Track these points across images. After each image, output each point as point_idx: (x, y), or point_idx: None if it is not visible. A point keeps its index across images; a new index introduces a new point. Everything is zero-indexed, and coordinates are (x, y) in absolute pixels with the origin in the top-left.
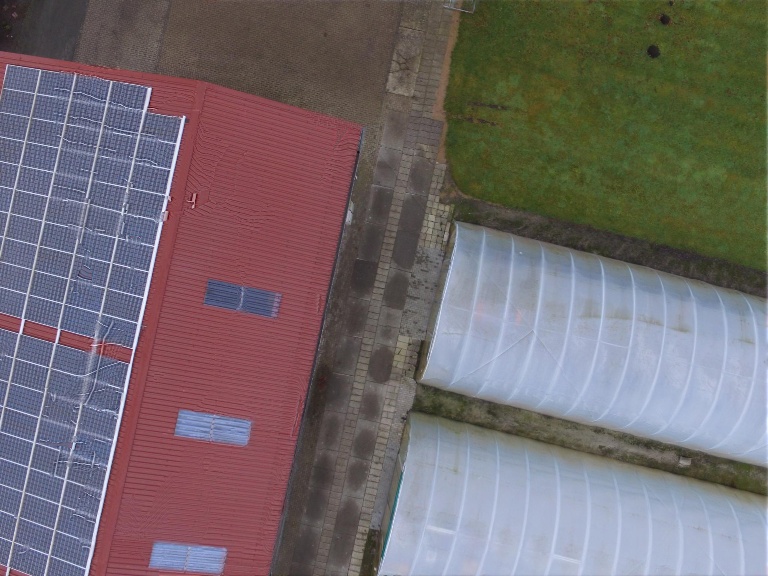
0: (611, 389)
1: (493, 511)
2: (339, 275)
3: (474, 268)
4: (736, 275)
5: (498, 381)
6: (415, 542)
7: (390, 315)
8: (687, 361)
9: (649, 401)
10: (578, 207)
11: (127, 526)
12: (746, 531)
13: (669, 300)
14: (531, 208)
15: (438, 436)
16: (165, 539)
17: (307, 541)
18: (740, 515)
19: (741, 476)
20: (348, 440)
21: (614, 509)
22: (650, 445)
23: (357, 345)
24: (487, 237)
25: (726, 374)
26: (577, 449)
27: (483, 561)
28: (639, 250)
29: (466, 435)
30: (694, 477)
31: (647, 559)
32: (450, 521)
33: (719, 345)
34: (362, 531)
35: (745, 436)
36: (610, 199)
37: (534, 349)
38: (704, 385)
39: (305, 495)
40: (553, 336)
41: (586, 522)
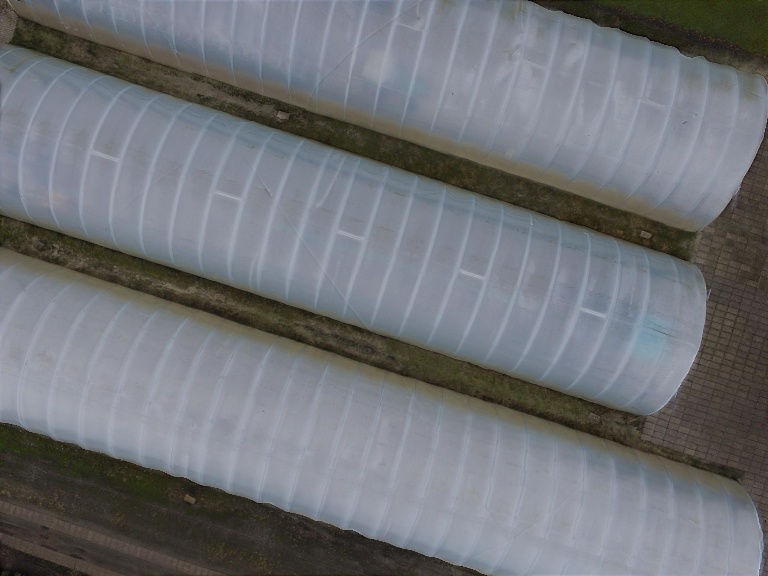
0: None
1: (37, 105)
2: None
3: None
4: None
5: None
6: None
7: None
8: None
9: (205, 11)
10: None
11: None
12: None
13: None
14: None
15: (12, 49)
16: None
17: None
18: (313, 153)
19: (338, 134)
20: None
21: (168, 120)
22: (249, 97)
23: None
24: None
25: None
26: (175, 95)
27: (22, 152)
28: None
29: (48, 57)
30: (291, 132)
31: (187, 163)
32: None
33: None
34: None
35: (308, 61)
36: None
37: None
38: None
39: None
40: None
41: (132, 125)
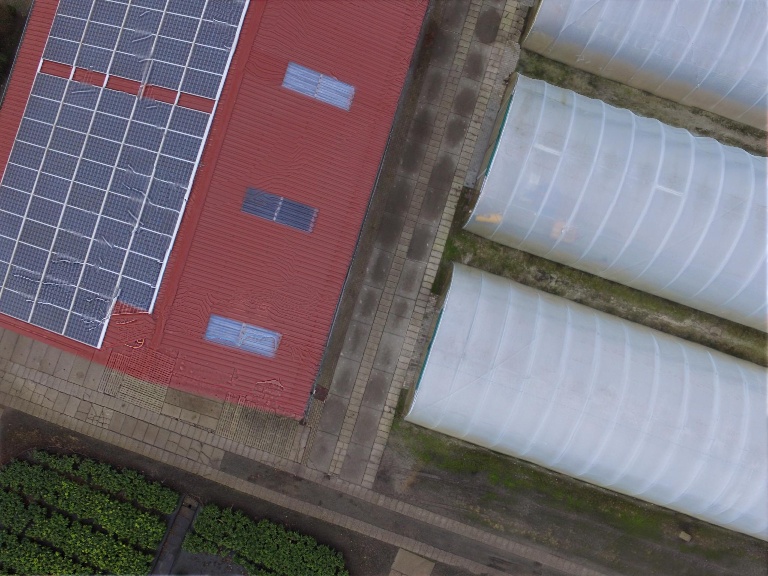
0: (724, 32)
1: (600, 138)
2: None
3: None
4: None
5: (610, 26)
6: (521, 158)
7: None
8: None
9: (761, 48)
10: None
11: (277, 6)
12: None
13: None
14: None
15: (544, 81)
16: (300, 59)
17: (401, 192)
18: None
19: None
20: (450, 96)
21: (717, 155)
22: (747, 131)
23: (466, 5)
24: None
25: None
26: None
27: (587, 184)
28: None
29: None
30: None
31: (749, 198)
32: (557, 141)
33: None
34: (456, 187)
35: None
36: None
37: None
38: None
39: (403, 147)
40: None
41: (690, 159)
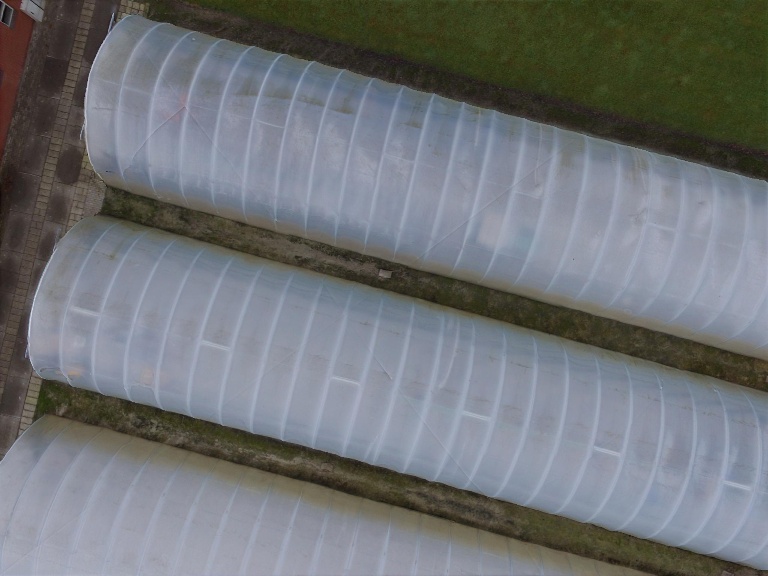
0: (271, 173)
1: (142, 294)
2: (29, 73)
3: (131, 44)
4: (444, 83)
5: (165, 169)
6: (57, 322)
7: (80, 115)
8: (346, 142)
9: (312, 187)
10: (280, 10)
11: None
12: (424, 333)
13: (341, 86)
14: (230, 10)
15: (107, 228)
16: None
17: None
18: (424, 320)
19: (443, 291)
20: (33, 242)
21: (276, 300)
22: (349, 256)
23: (45, 145)
24: (164, 25)
25: (387, 157)
26: (272, 258)
27: (129, 345)
28: (342, 55)
29: (143, 232)
30: (394, 291)
31: (301, 348)
32: (95, 302)
33: (382, 127)
34: None
35: (419, 230)
36: (313, 2)
37: (187, 126)
38: (364, 168)
39: None
40: (206, 113)
41: (241, 310)
